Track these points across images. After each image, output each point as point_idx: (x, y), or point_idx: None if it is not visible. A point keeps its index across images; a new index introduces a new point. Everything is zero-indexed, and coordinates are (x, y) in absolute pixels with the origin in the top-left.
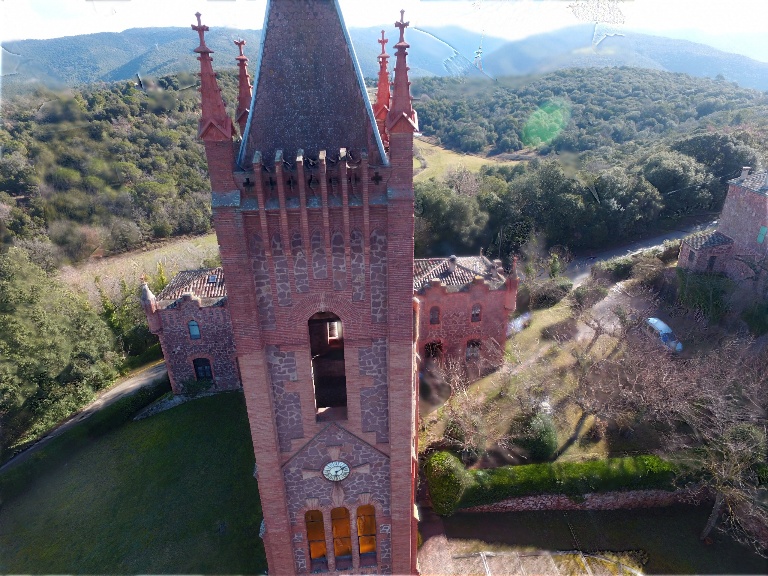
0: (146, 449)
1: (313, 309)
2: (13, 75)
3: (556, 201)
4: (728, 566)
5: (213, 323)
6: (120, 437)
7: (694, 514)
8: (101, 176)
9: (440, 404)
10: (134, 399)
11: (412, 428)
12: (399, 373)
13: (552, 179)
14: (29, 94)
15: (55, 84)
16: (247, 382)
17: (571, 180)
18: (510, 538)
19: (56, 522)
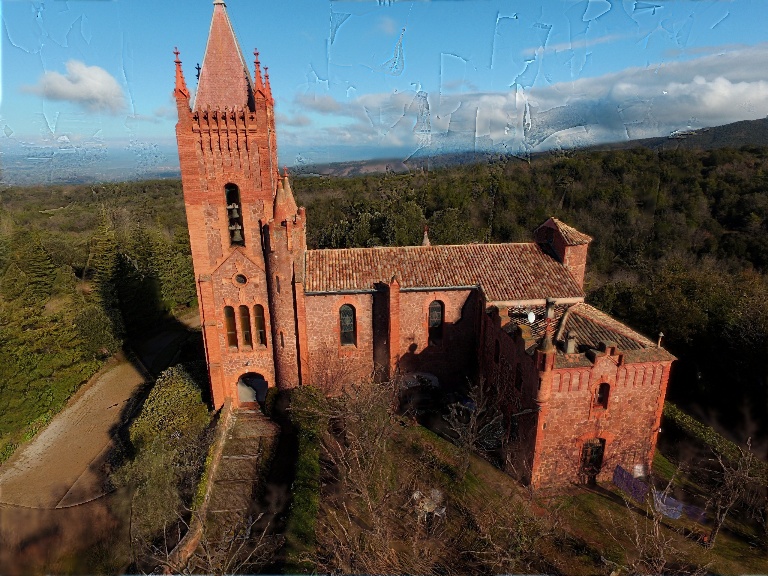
0: None
1: None
2: (563, 107)
3: None
4: None
5: None
6: None
7: None
8: (631, 194)
9: (432, 428)
10: None
11: (278, 321)
12: None
13: None
14: (570, 120)
15: (605, 113)
16: None
17: None
18: (272, 478)
19: None
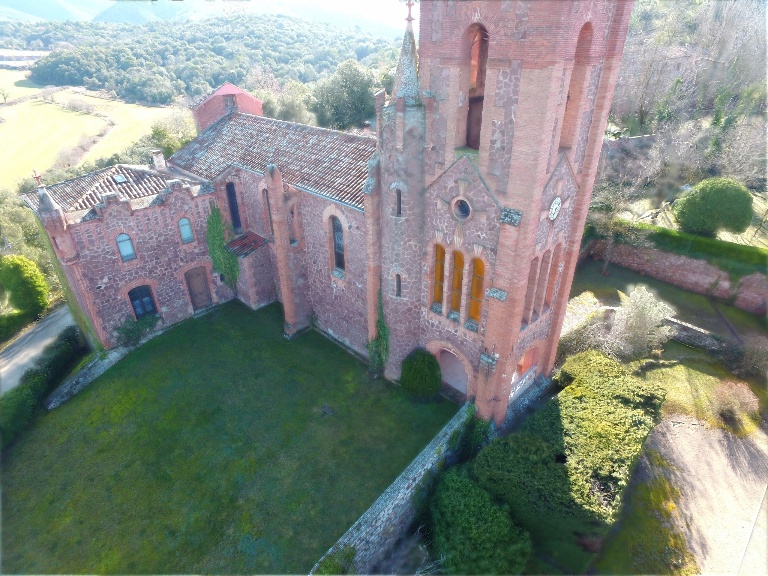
0: (126, 414)
1: (585, 18)
2: None
3: (366, 96)
4: (622, 280)
5: (150, 232)
6: (53, 431)
7: (588, 265)
8: None
9: None
10: (31, 385)
11: None
12: (610, 90)
13: (355, 77)
14: None
15: None
16: (550, 99)
17: (371, 76)
18: None
19: (72, 540)
